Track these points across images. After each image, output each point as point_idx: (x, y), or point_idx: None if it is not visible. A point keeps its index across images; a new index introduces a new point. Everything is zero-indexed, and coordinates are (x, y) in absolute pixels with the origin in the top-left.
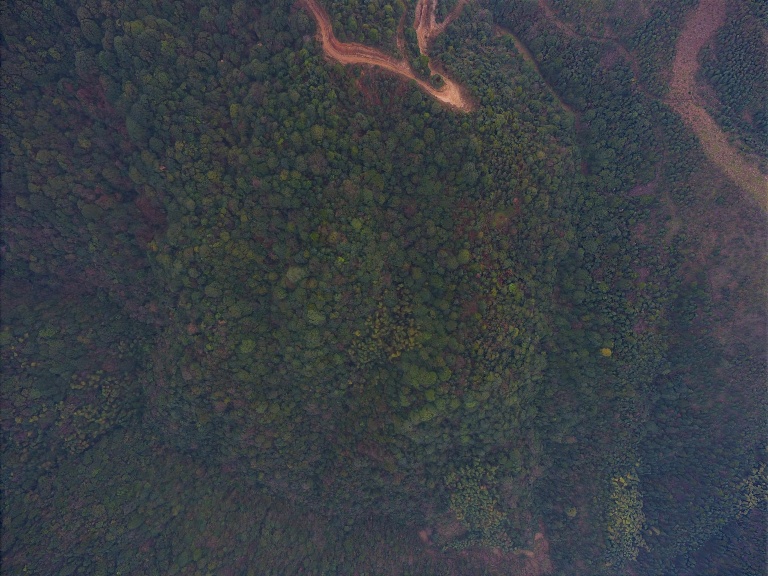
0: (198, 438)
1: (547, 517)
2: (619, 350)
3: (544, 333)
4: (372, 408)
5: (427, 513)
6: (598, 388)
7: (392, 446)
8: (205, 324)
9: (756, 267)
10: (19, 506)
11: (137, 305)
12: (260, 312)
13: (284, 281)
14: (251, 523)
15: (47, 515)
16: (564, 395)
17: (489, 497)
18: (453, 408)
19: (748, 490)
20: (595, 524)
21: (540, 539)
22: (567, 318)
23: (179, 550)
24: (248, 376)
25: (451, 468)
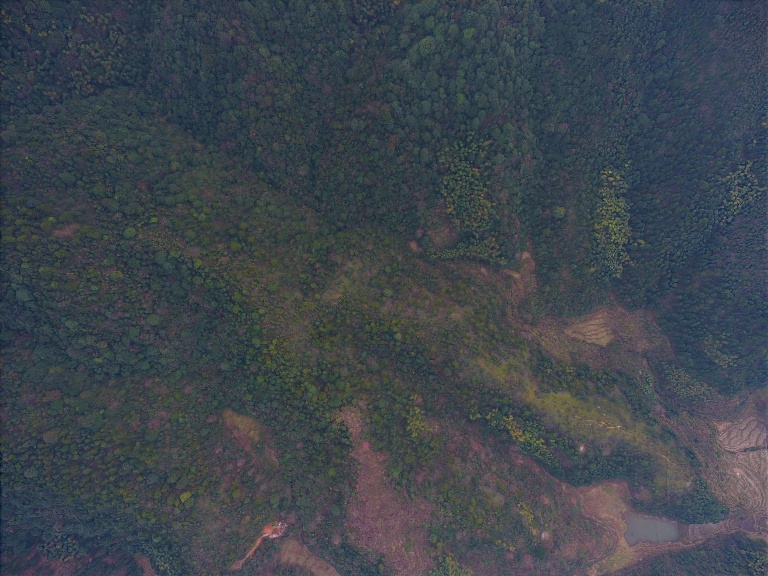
0: (200, 101)
1: (535, 227)
2: None
3: None
4: (372, 68)
5: (419, 205)
6: (593, 46)
7: (389, 93)
8: None
9: None
10: None
11: None
12: None
13: None
14: (247, 194)
15: None
16: (560, 64)
17: (480, 182)
18: (451, 36)
19: (734, 188)
20: (582, 223)
21: (527, 259)
22: None
23: (176, 190)
24: (253, 9)
25: (445, 143)
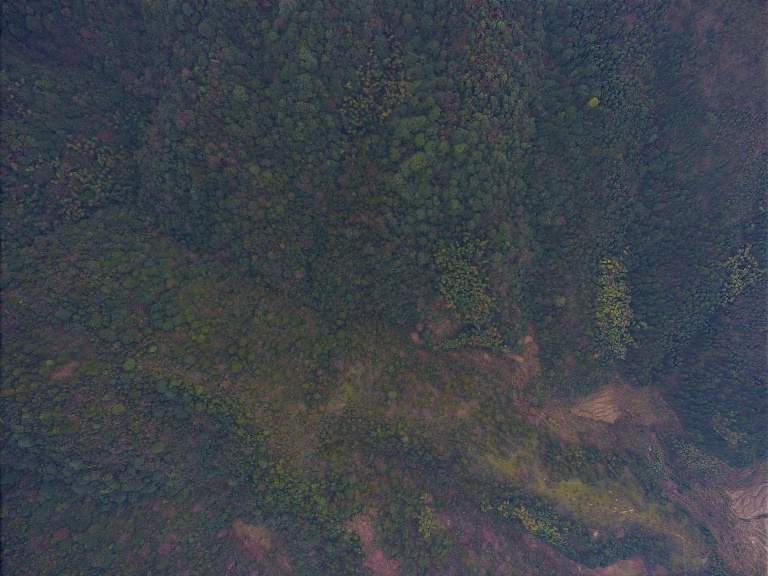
0: (192, 215)
1: (537, 314)
2: (606, 98)
3: (533, 93)
4: (363, 177)
5: (418, 302)
6: (586, 147)
7: (383, 205)
8: (199, 67)
9: (740, 2)
10: (15, 258)
11: (132, 77)
12: (253, 67)
13: (276, 21)
14: (244, 304)
15: (43, 264)
16: (553, 163)
17: (479, 279)
18: (442, 152)
19: (734, 272)
20: (583, 312)
21: (530, 343)
22: (556, 79)
23: (173, 312)
24: (241, 130)
25: (441, 244)
